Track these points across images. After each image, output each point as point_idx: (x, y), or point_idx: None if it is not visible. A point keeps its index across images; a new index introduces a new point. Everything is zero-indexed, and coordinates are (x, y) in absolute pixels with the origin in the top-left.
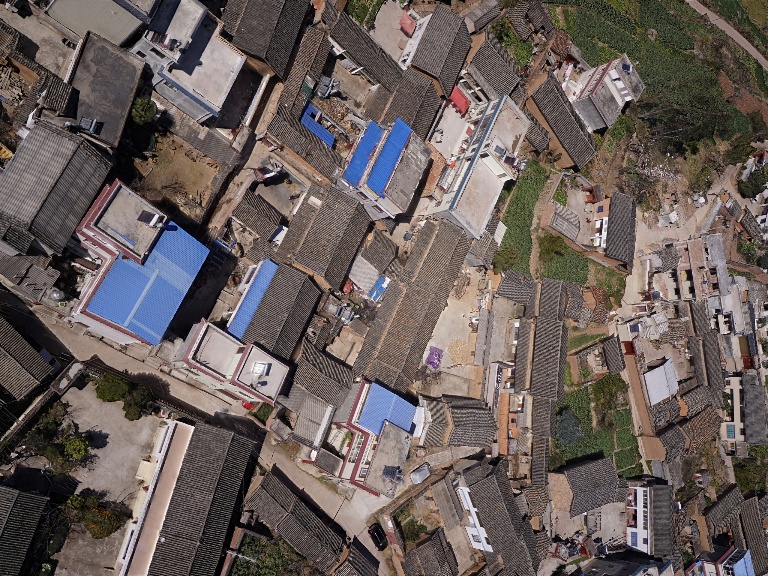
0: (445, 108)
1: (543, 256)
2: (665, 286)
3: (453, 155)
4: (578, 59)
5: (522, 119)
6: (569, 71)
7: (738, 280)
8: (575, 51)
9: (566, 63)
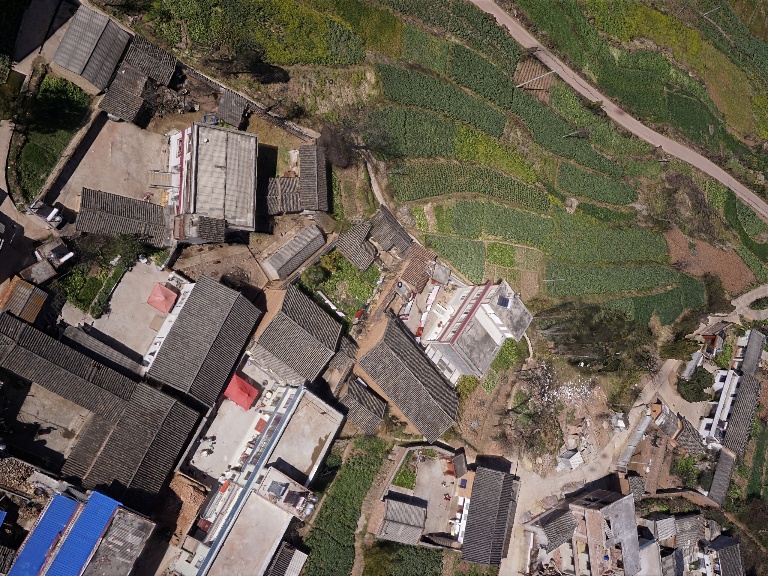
0: (222, 402)
1: (366, 575)
2: (559, 553)
3: (230, 467)
4: (444, 282)
5: (332, 412)
6: (433, 296)
7: (662, 525)
8: (440, 272)
9: (431, 282)
